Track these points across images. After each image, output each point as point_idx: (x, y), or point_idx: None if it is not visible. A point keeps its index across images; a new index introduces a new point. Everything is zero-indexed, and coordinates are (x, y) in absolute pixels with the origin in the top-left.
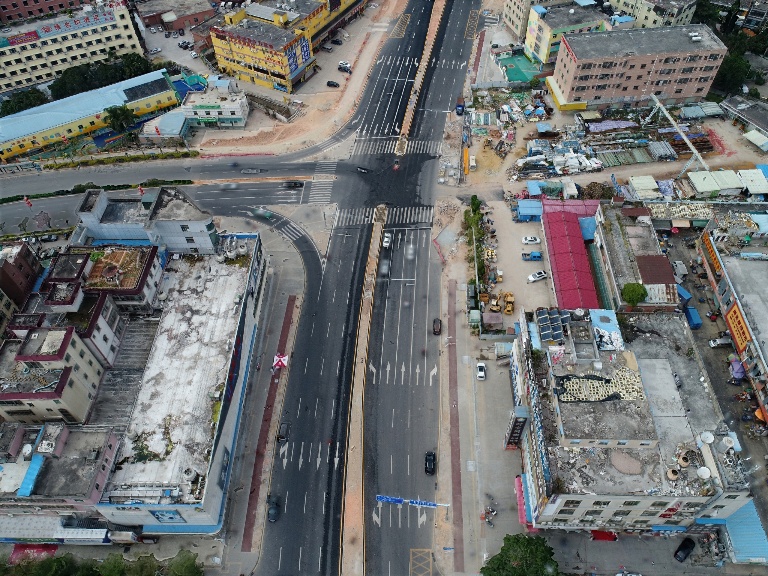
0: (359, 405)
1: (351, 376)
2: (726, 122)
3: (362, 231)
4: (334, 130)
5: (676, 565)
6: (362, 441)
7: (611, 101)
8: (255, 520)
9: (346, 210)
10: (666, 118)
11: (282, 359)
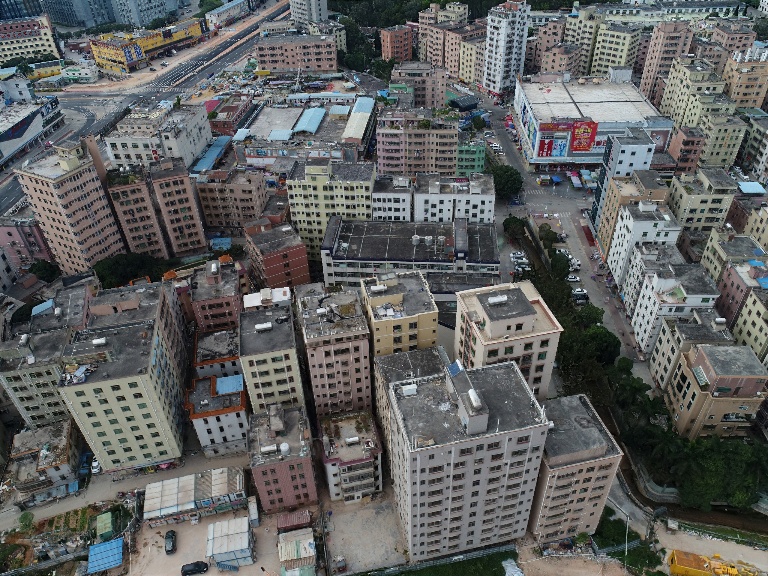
0: None
1: None
2: (343, 81)
3: None
4: (139, 84)
5: None
6: None
7: (283, 71)
8: (7, 180)
9: None
10: (312, 79)
11: (50, 142)
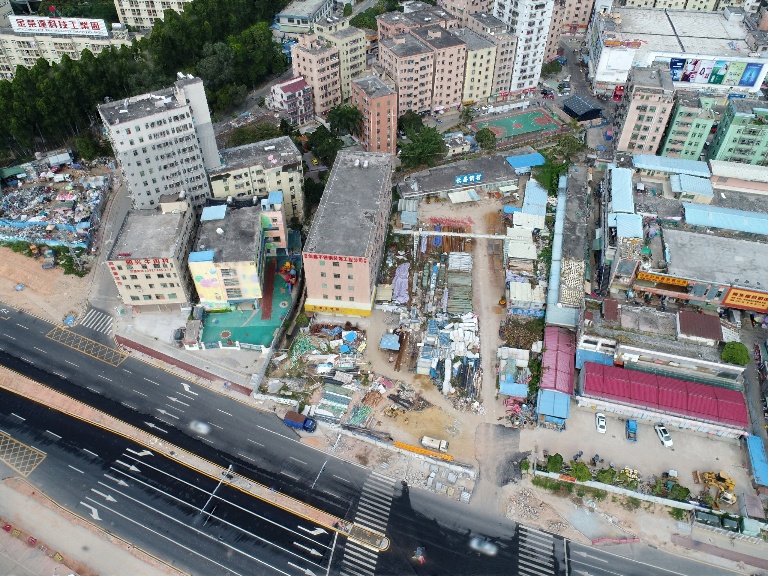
0: None
1: None
2: (422, 206)
3: None
4: None
5: None
6: None
7: None
8: None
9: None
10: (406, 239)
11: None
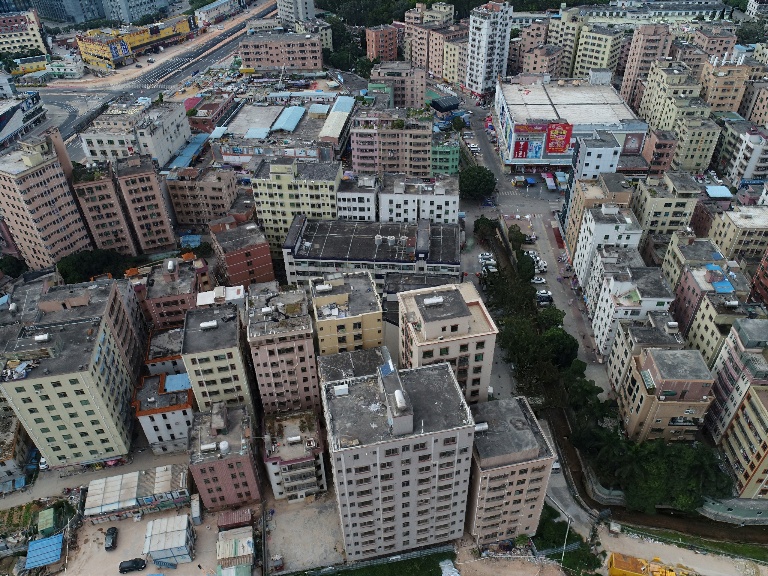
0: None
1: None
2: (328, 80)
3: None
4: (124, 80)
5: None
6: None
7: (268, 69)
8: None
9: None
10: (296, 78)
11: None
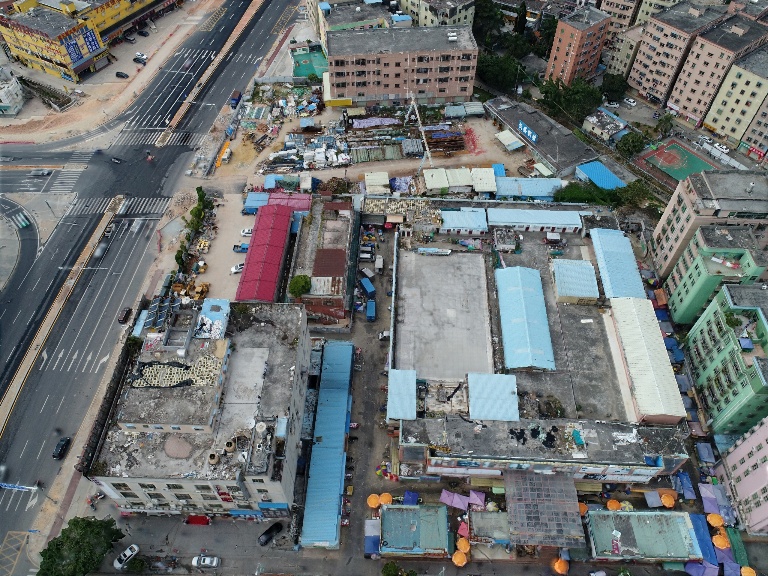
0: (15, 391)
1: (20, 362)
2: (488, 122)
3: (91, 220)
4: (104, 120)
5: (257, 549)
6: (4, 426)
7: (376, 98)
8: None
9: (84, 199)
10: (430, 116)
11: None
